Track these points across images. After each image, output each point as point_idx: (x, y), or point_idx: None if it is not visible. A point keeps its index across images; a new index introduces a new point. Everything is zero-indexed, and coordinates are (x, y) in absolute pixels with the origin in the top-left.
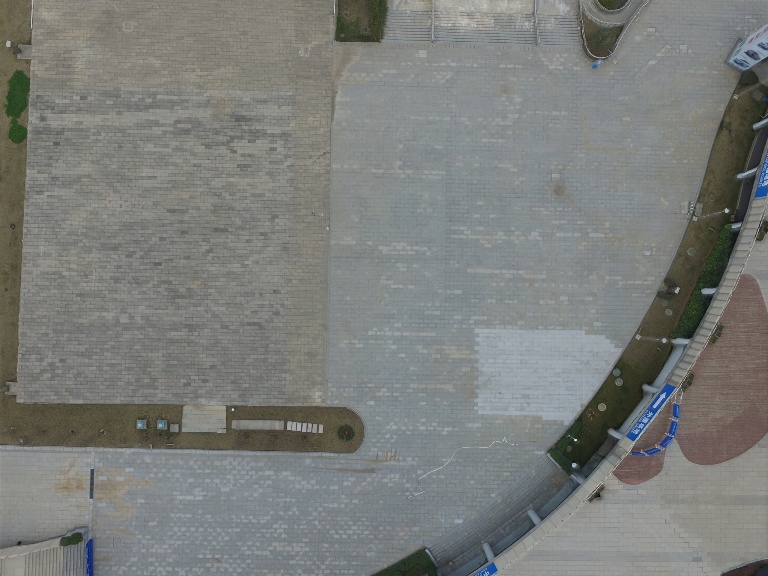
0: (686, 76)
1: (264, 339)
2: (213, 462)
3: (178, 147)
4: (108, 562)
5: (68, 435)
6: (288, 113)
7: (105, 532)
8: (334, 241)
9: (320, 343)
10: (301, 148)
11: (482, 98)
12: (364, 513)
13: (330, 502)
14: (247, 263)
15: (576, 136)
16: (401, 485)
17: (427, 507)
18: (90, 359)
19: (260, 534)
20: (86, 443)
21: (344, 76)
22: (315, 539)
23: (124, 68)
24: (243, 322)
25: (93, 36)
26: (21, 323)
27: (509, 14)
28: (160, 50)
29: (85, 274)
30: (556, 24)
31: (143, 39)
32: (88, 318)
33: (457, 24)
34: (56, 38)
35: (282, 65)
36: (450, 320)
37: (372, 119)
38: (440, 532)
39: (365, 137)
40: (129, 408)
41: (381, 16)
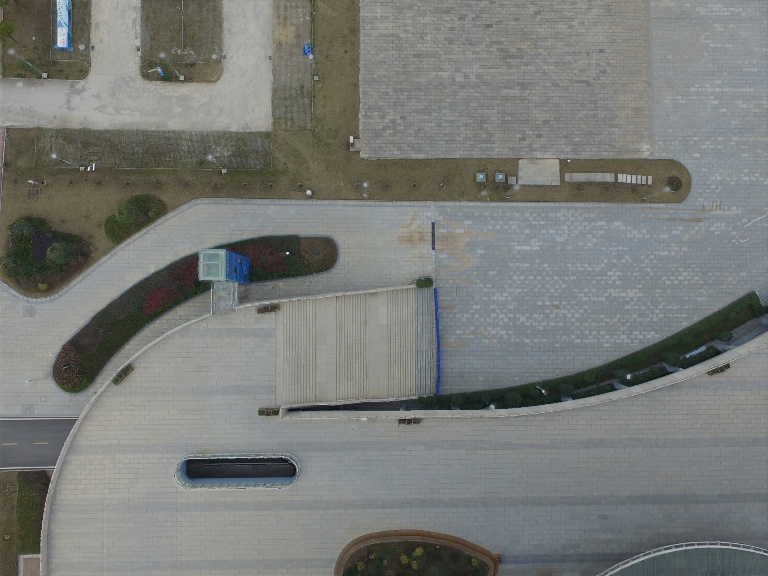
0: None
1: (593, 96)
2: (548, 214)
3: None
4: (452, 310)
5: (410, 189)
6: None
7: (448, 281)
8: (654, 3)
9: (646, 99)
10: None
11: None
12: (693, 260)
13: (661, 250)
14: (573, 24)
15: None
16: (727, 233)
17: (753, 253)
18: (429, 116)
19: (595, 281)
20: (426, 197)
21: None
22: (648, 285)
23: None
24: (572, 80)
25: None
26: (362, 82)
27: None
28: None
29: (421, 36)
30: None
31: None
32: (426, 77)
33: None
34: None
35: None
36: (767, 76)
37: None
38: (766, 277)
39: None
40: (468, 162)
41: None
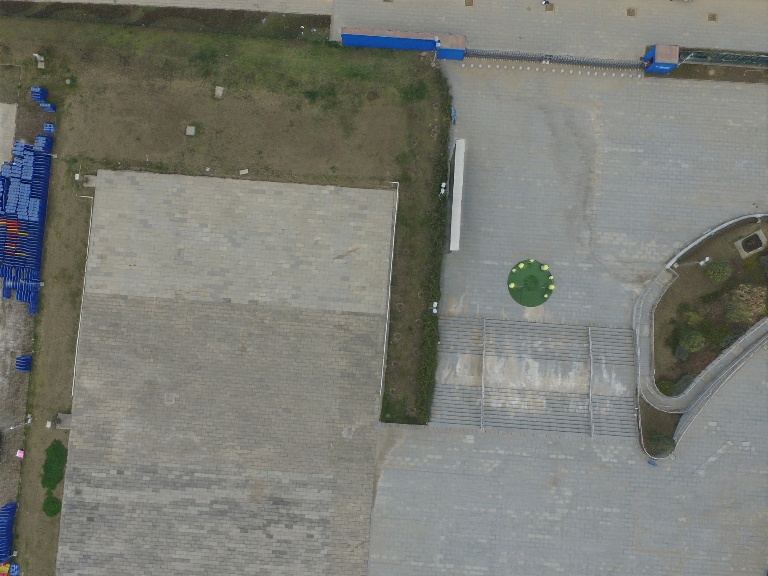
0: (748, 476)
1: None
2: None
3: (213, 529)
4: None
5: None
6: (328, 498)
7: None
8: None
9: None
10: (339, 536)
11: (530, 490)
12: None
13: None
14: None
15: (628, 536)
16: None
17: None
18: None
19: None
20: None
21: (387, 460)
22: None
23: (163, 442)
24: None
25: (134, 407)
26: None
27: (562, 393)
28: (200, 425)
29: None
30: (611, 408)
31: (184, 413)
32: None
33: (507, 404)
34: (96, 408)
35: (324, 446)
36: None
37: (414, 507)
38: None
39: (406, 526)
40: None
41: (429, 398)
